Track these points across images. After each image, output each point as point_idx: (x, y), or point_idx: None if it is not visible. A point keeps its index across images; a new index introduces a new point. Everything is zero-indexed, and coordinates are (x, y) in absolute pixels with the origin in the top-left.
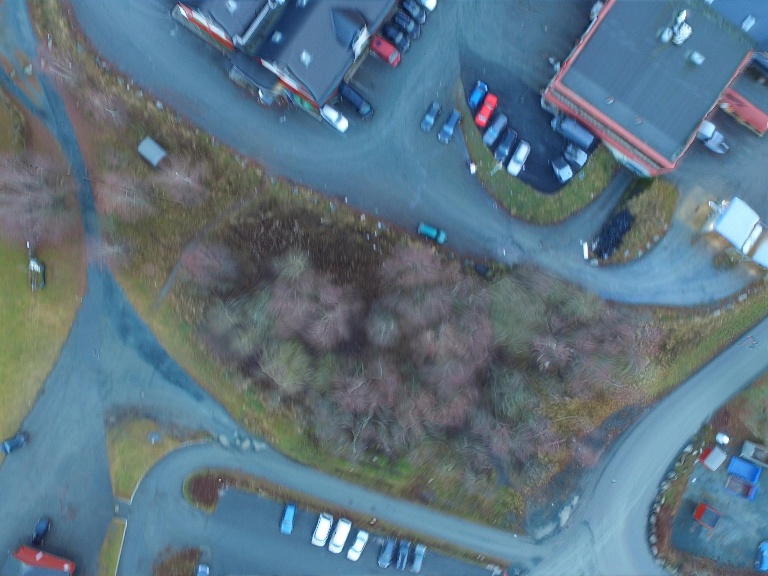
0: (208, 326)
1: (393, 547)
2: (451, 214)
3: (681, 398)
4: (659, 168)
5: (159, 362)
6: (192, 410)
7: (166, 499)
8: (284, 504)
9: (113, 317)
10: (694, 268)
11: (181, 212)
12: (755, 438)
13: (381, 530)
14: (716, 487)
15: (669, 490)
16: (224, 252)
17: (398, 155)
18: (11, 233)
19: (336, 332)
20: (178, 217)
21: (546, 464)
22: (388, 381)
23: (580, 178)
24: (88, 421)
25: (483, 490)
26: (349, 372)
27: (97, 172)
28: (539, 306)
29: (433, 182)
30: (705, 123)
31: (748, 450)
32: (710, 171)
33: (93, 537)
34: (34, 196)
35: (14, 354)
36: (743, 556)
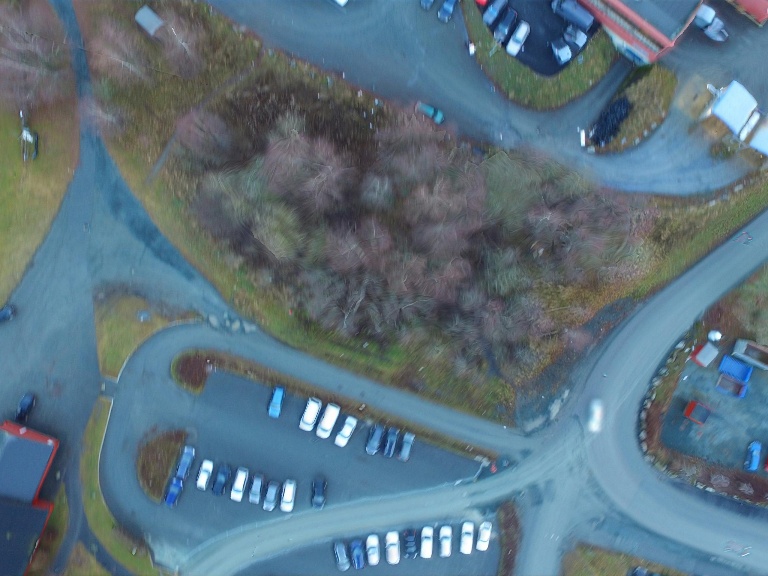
0: (201, 203)
1: (381, 433)
2: (449, 95)
3: (674, 294)
4: (658, 50)
5: (150, 239)
6: (182, 289)
7: (153, 379)
8: (273, 387)
9: (105, 191)
10: (691, 157)
11: (177, 85)
12: (747, 335)
13: (370, 417)
14: (707, 386)
15: (660, 386)
16: (219, 127)
17: (397, 32)
18: (4, 101)
19: (330, 197)
20: (174, 90)
21: (537, 355)
22: (381, 251)
23: (579, 62)
24: (77, 297)
25: (473, 380)
26: (342, 233)
27: (93, 42)
28: (535, 178)
29: (431, 61)
30: (705, 8)
31: (740, 347)
32: (709, 60)
33: (78, 415)
34: (29, 63)
35: (4, 226)
36: (732, 456)
